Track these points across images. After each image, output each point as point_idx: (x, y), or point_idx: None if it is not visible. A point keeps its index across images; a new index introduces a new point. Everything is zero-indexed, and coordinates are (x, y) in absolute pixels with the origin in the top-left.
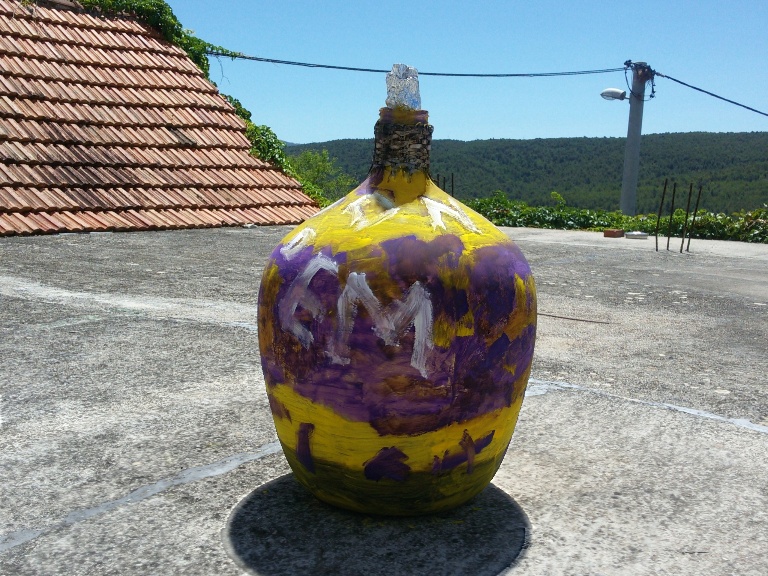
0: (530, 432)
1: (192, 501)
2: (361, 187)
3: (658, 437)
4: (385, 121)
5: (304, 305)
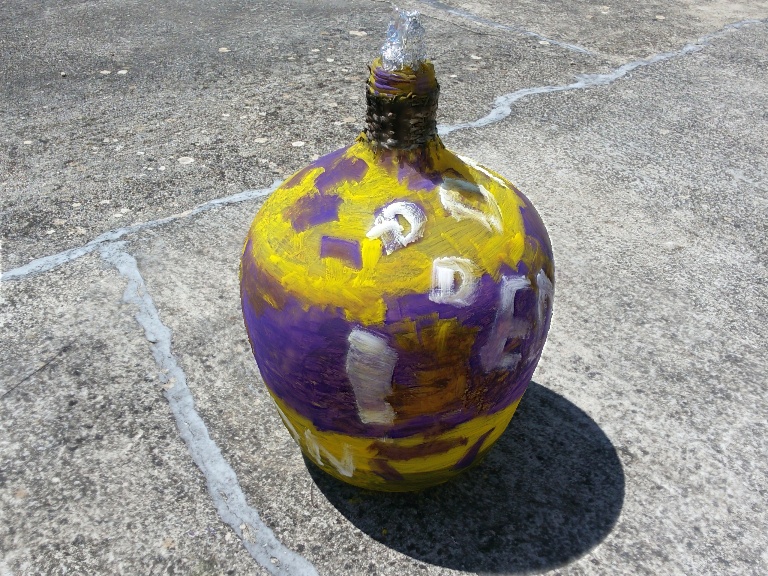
0: None
1: None
2: (415, 178)
3: None
4: (425, 90)
5: (514, 335)
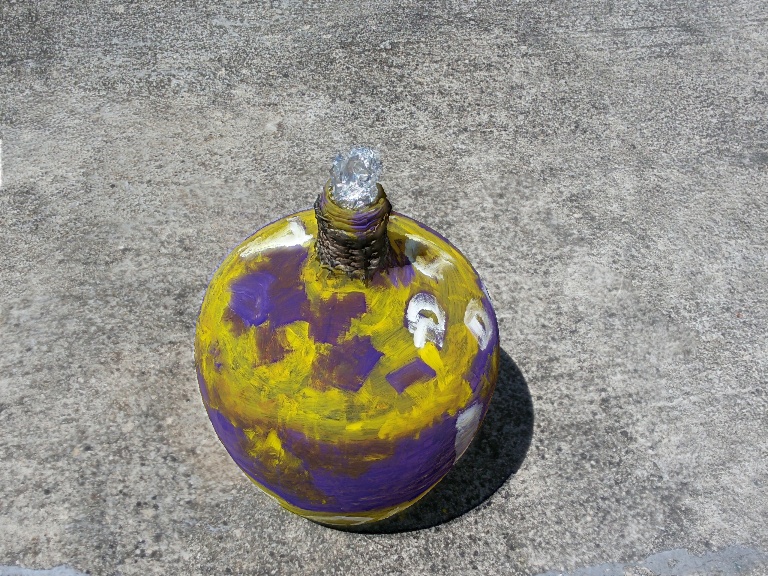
0: (88, 461)
1: (510, 538)
2: (401, 273)
3: (7, 369)
4: None
5: None
